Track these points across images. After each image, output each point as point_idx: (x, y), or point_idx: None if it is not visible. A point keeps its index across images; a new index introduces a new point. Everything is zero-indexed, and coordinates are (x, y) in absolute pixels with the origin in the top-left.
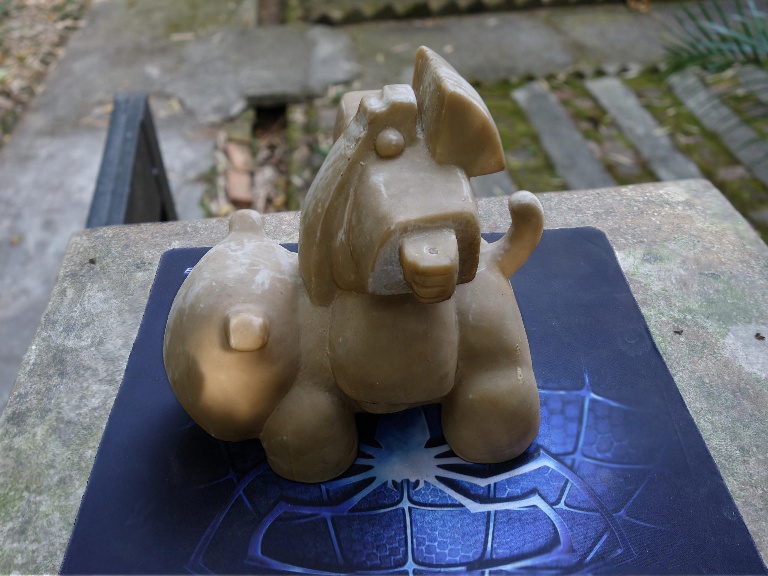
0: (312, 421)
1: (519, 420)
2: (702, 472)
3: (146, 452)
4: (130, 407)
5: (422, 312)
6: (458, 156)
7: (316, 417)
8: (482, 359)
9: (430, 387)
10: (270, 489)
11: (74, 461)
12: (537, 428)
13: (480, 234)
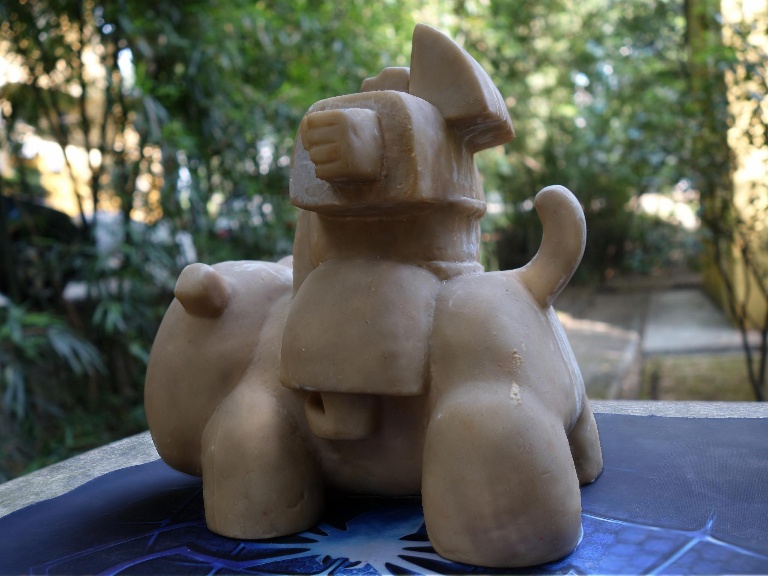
0: (243, 425)
1: (508, 466)
2: None
3: (115, 496)
4: (143, 472)
5: (373, 266)
6: (431, 94)
7: (249, 421)
8: (460, 361)
9: (367, 366)
10: (186, 536)
11: (57, 494)
12: (555, 511)
13: (415, 127)
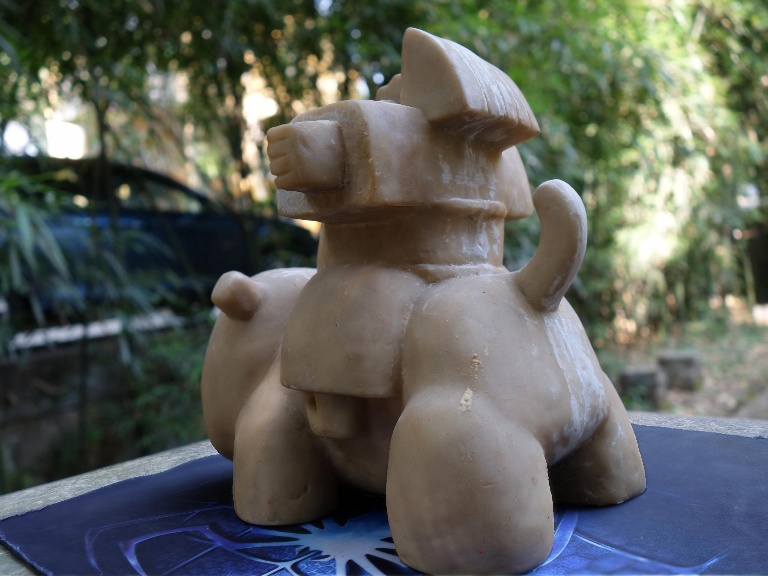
0: (257, 419)
1: (448, 474)
2: None
3: (196, 477)
4: None
5: (353, 271)
6: (418, 97)
7: (262, 415)
8: (424, 365)
9: (334, 367)
10: (217, 516)
11: None
12: (498, 525)
13: (372, 133)
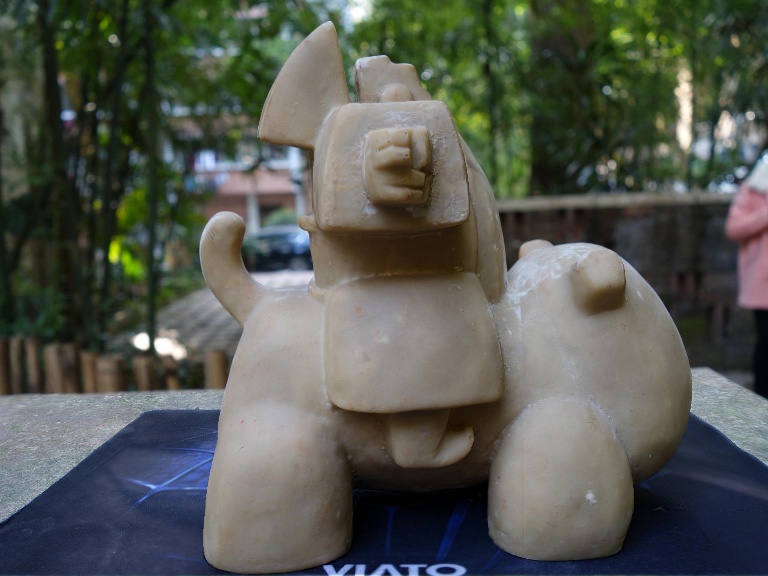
0: None
1: None
2: (118, 445)
3: (692, 457)
4: (762, 487)
5: None
6: None
7: None
8: None
9: None
10: None
11: None
12: None
13: None
